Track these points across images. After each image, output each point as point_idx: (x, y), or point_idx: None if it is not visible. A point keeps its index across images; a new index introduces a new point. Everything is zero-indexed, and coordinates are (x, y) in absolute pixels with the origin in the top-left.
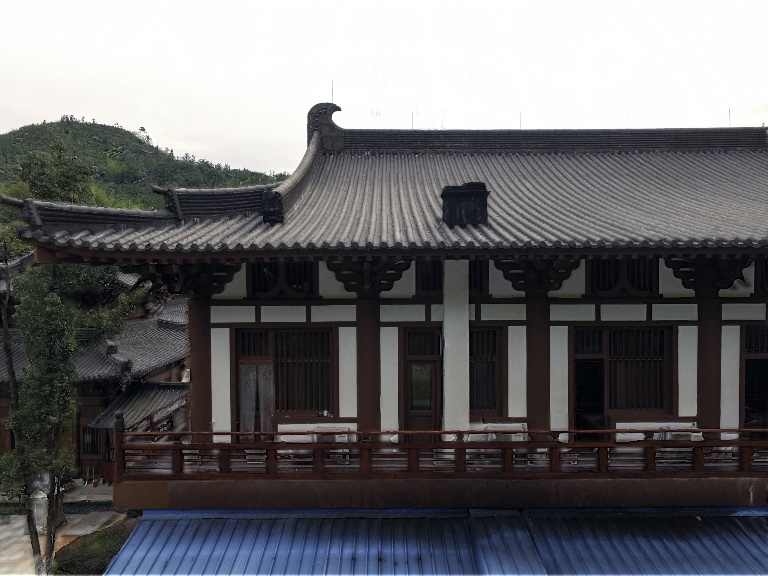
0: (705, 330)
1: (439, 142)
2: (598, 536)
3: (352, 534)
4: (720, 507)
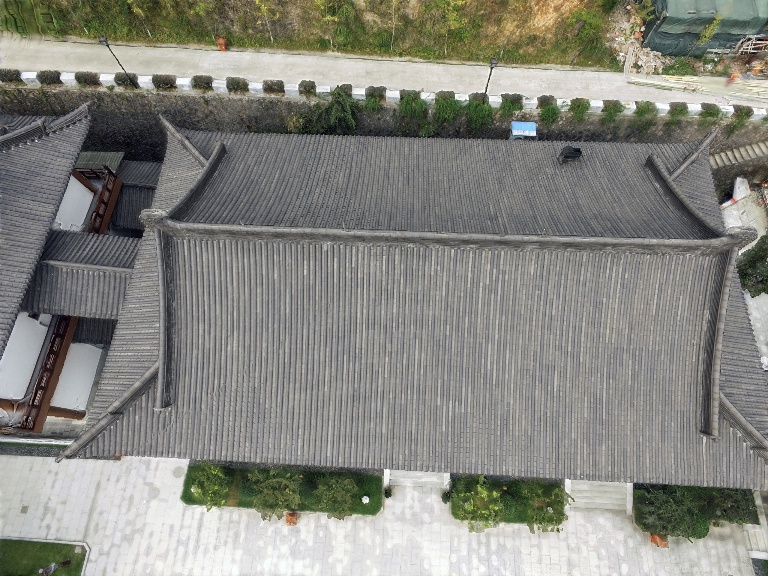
0: None
1: None
2: None
3: None
4: None
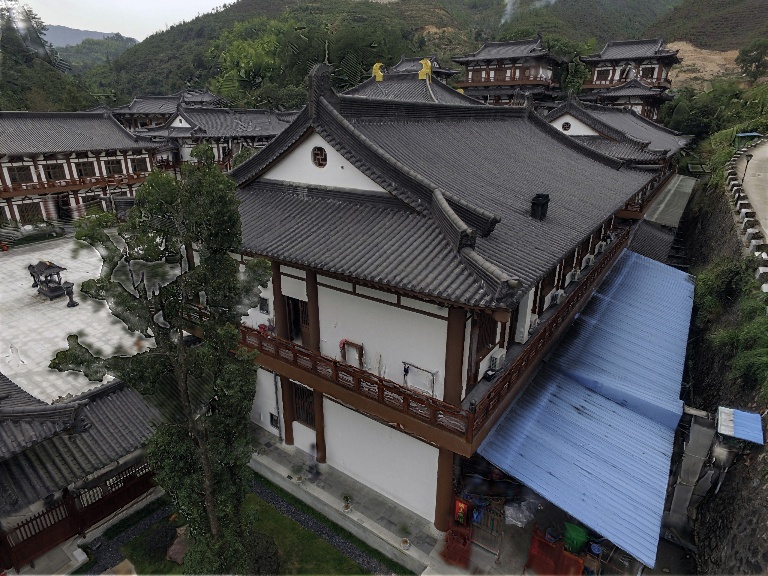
0: None
1: (392, 111)
2: (569, 346)
3: (536, 394)
4: None
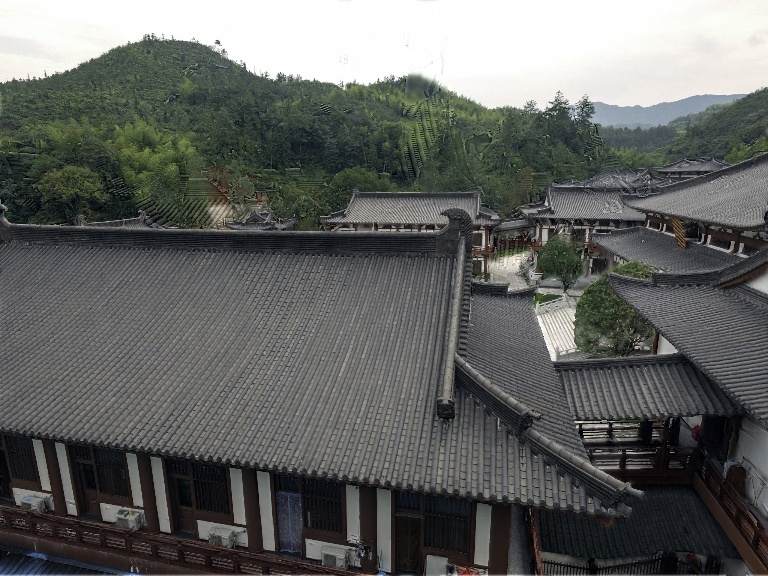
0: (45, 444)
1: (70, 237)
2: None
3: None
4: (22, 549)
